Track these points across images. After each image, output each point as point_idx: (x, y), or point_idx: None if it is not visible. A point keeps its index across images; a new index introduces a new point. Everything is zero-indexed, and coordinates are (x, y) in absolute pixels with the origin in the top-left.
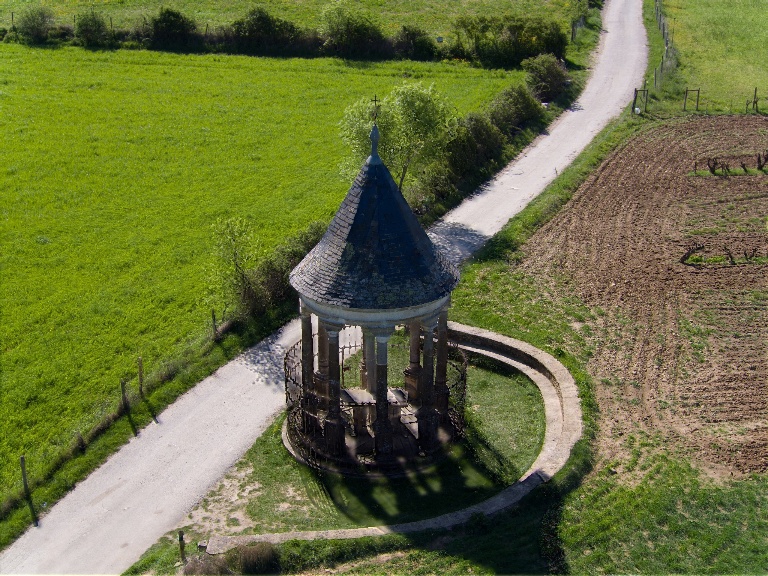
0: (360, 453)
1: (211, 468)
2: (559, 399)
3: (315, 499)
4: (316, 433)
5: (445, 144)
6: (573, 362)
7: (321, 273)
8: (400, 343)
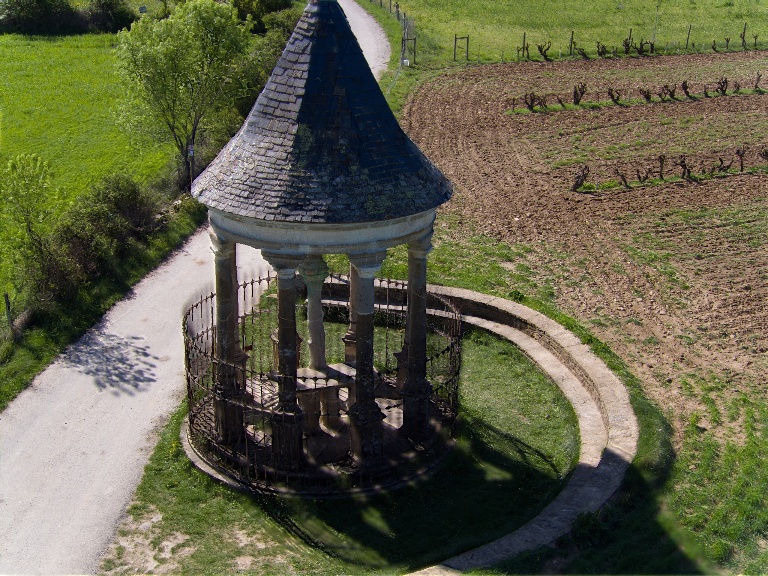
0: (329, 461)
1: (89, 524)
2: (550, 352)
3: (289, 542)
4: (245, 443)
5: (253, 74)
6: (541, 305)
7: (260, 177)
8: None
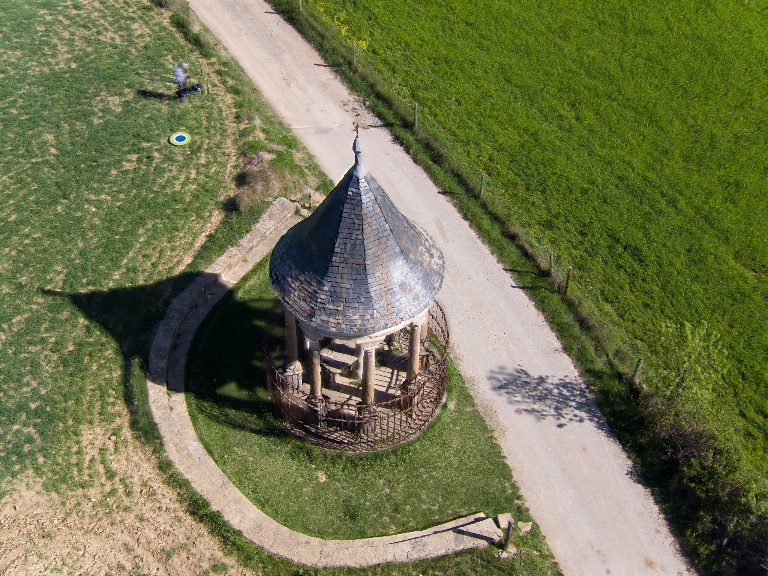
0: None
1: None
2: None
3: None
4: None
5: None
6: (279, 574)
7: None
8: (495, 510)
